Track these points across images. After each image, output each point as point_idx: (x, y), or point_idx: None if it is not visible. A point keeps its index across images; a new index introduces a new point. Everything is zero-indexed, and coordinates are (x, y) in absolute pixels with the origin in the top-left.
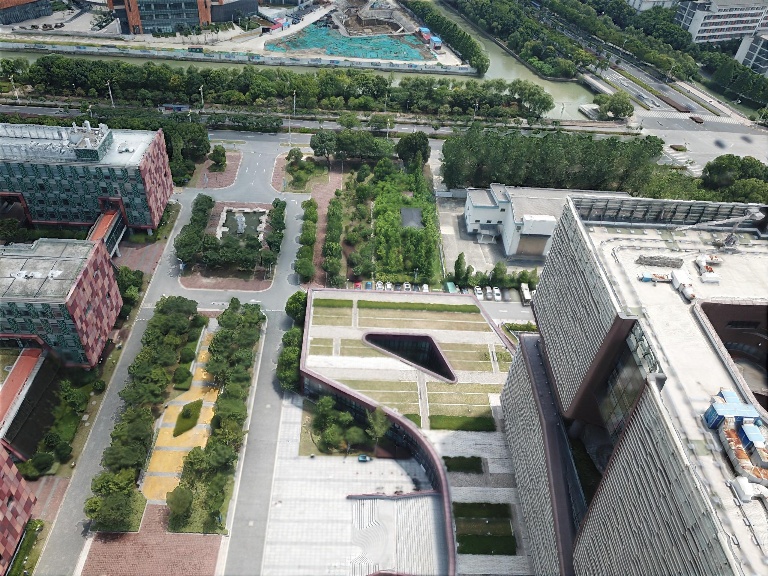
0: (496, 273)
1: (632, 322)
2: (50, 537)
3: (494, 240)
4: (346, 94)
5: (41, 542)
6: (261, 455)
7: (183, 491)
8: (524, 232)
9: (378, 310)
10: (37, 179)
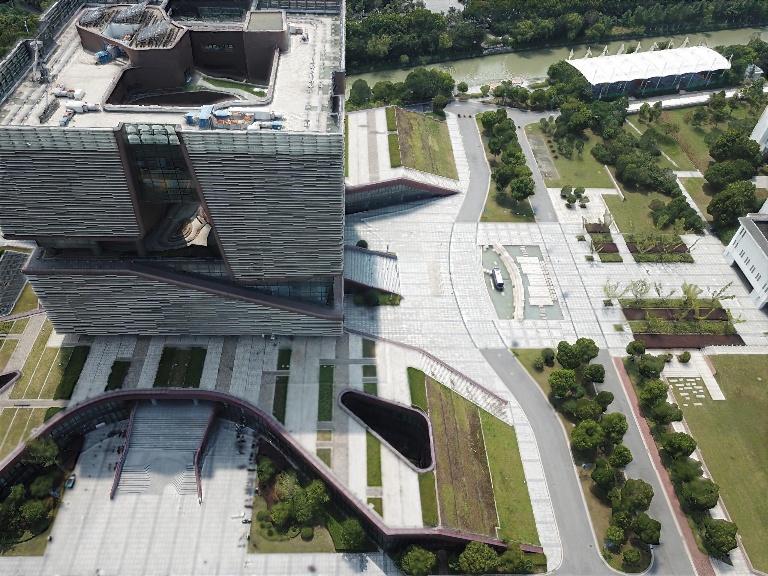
0: None
1: (124, 128)
2: None
3: None
4: None
5: None
6: None
7: None
8: None
9: None
10: None
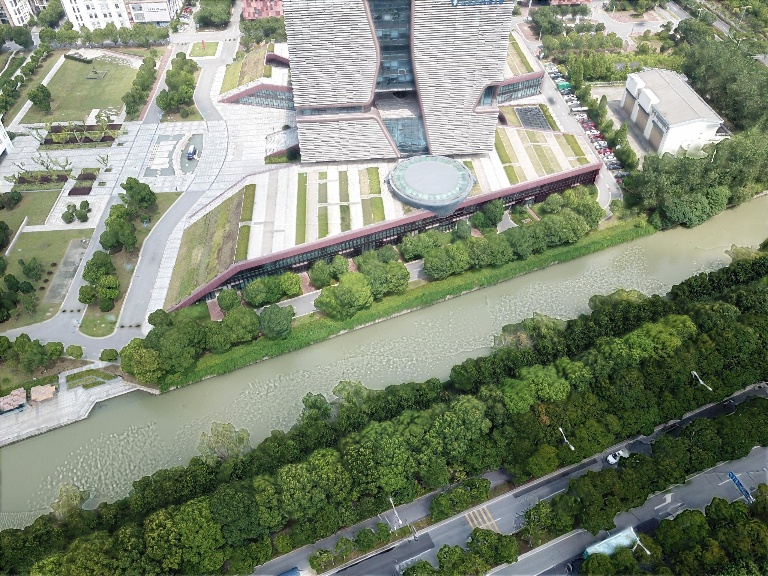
0: None
1: None
2: None
3: None
4: None
5: None
6: None
7: None
8: (626, 85)
9: None
10: None
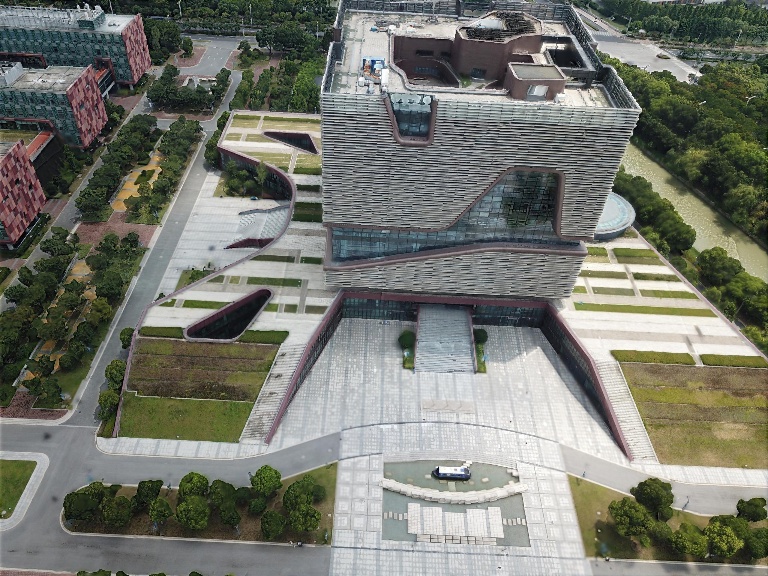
0: None
1: (340, 30)
2: (55, 223)
3: None
4: (293, 10)
5: (49, 224)
6: (189, 195)
7: (134, 197)
8: None
9: (277, 121)
10: (52, 43)
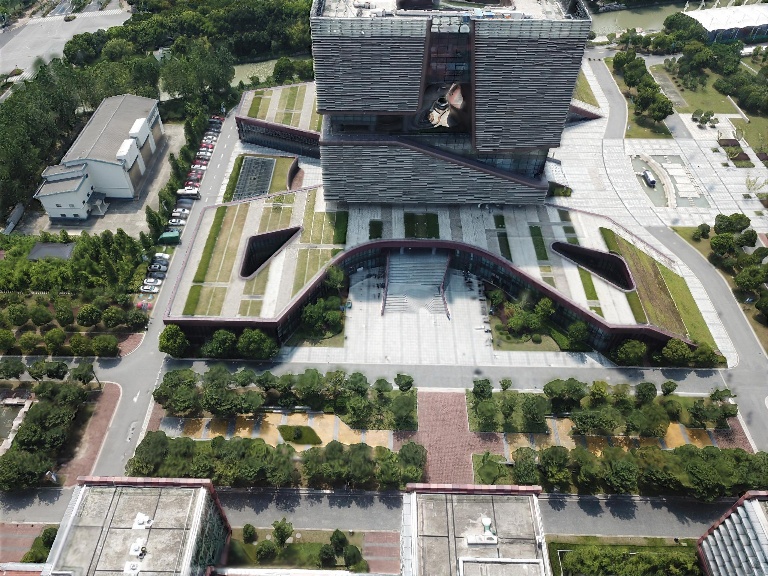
0: (166, 200)
1: None
2: None
3: (105, 203)
4: None
5: None
6: None
7: (396, 403)
8: (130, 166)
9: (209, 269)
10: None
